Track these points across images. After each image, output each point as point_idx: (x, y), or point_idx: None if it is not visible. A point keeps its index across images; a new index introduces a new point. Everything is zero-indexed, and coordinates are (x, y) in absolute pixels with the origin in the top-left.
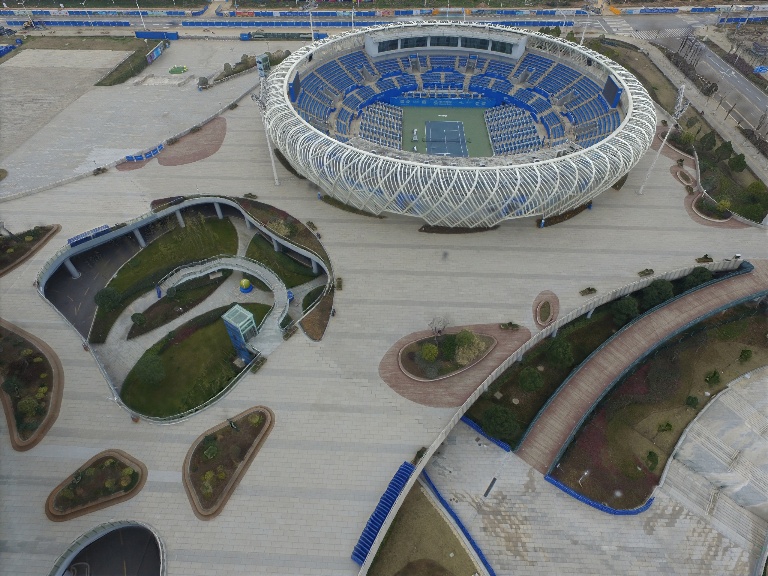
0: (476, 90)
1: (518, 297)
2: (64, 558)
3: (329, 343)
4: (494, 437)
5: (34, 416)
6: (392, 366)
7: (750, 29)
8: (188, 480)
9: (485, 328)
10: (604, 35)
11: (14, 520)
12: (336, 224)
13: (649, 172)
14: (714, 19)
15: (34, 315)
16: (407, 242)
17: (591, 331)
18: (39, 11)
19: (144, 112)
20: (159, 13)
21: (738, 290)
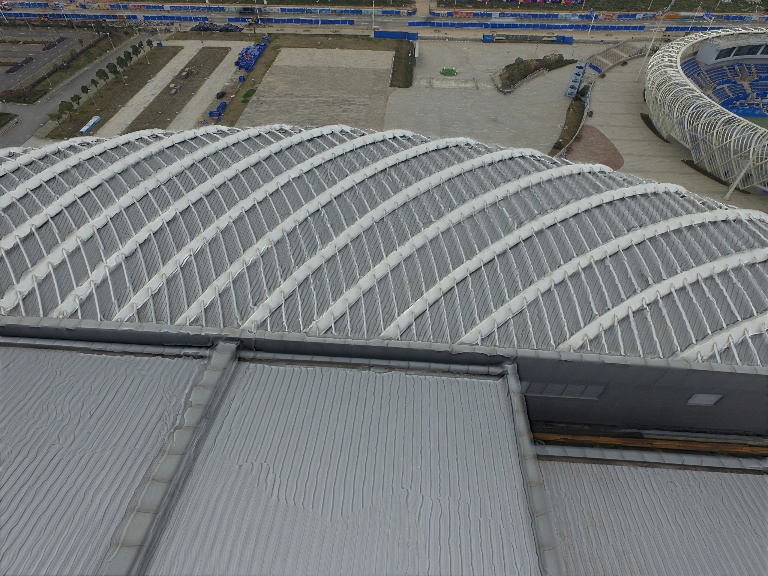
0: None
1: None
2: None
3: None
4: None
5: None
6: None
7: None
8: None
9: None
10: None
11: None
12: None
13: None
14: None
15: None
16: None
17: None
18: (251, 7)
19: (470, 116)
20: (374, 12)
21: None
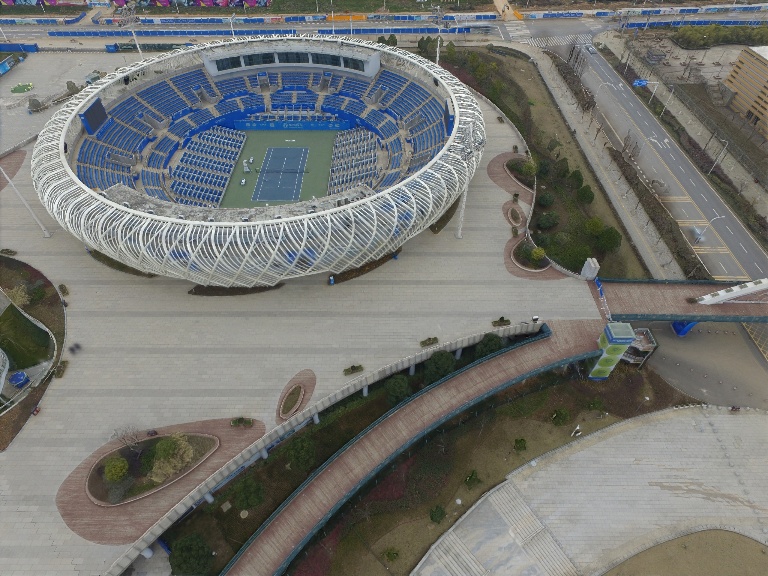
0: (329, 111)
1: (269, 380)
2: None
3: (13, 454)
4: None
5: None
6: (77, 485)
7: (651, 35)
8: None
9: (213, 425)
10: (492, 44)
11: None
12: (94, 287)
13: (461, 215)
14: (616, 24)
15: None
16: (168, 309)
17: (365, 412)
18: None
19: None
20: (28, 21)
21: (529, 361)
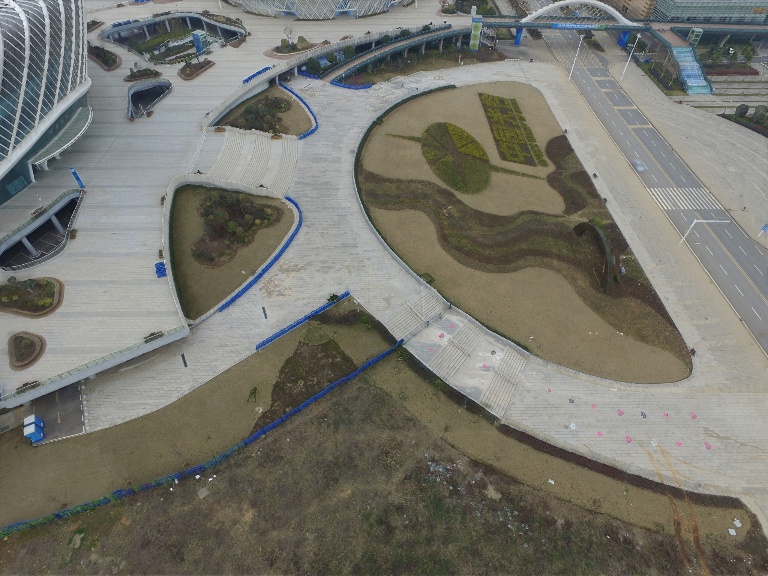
0: None
1: (335, 36)
2: (134, 86)
3: (242, 48)
4: (312, 74)
5: (112, 62)
6: (269, 52)
7: None
8: (180, 73)
9: (315, 43)
10: None
11: (111, 82)
12: (251, 19)
13: None
14: None
15: (101, 45)
16: (286, 24)
17: None
18: None
19: None
20: None
21: None
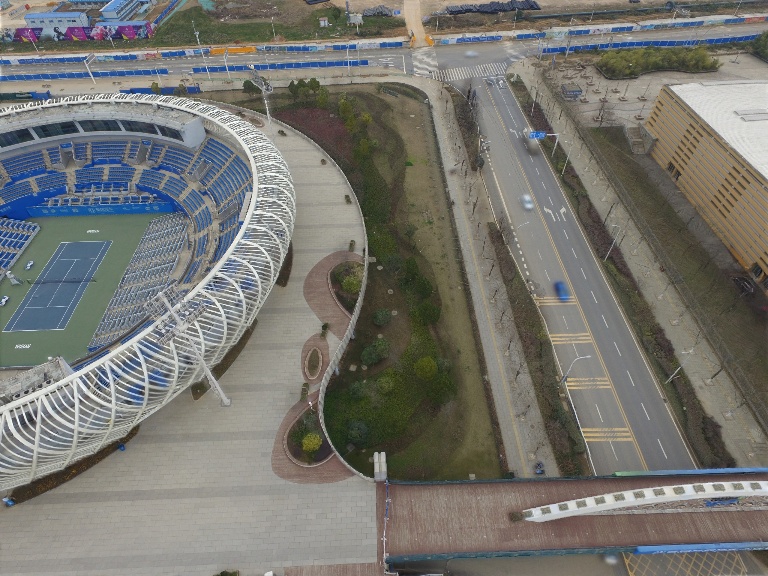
0: (147, 190)
1: None
2: None
3: None
4: None
5: None
6: None
7: (574, 61)
8: None
9: None
10: (380, 84)
11: None
12: None
13: (212, 386)
14: (535, 50)
15: None
16: None
17: None
18: None
19: None
20: None
21: None
